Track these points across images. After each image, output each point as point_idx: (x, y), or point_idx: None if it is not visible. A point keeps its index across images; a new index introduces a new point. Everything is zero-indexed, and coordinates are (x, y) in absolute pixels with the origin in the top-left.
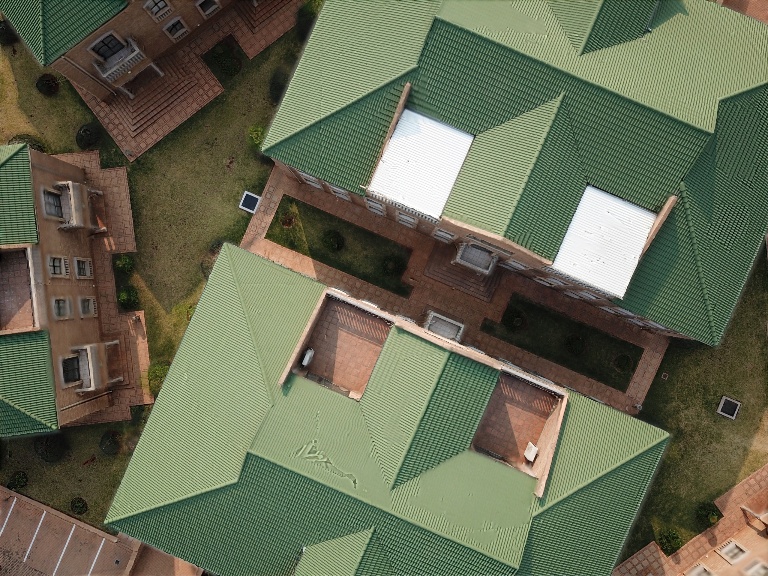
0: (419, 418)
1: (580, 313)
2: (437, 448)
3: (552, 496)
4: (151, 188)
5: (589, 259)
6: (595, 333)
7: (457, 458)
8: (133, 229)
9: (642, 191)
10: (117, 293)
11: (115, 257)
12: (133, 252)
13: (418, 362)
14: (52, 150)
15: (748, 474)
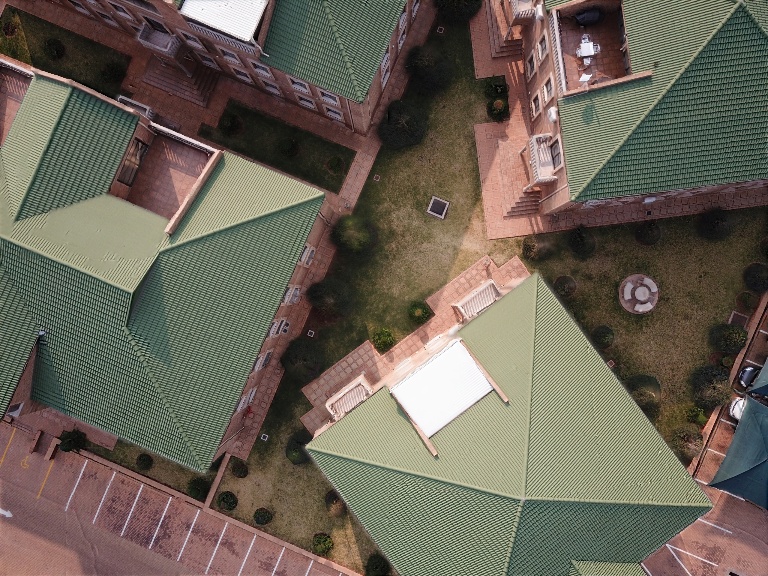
0: (42, 151)
1: (294, 117)
2: (68, 187)
3: (185, 236)
4: None
5: (217, 4)
6: (309, 136)
7: (93, 200)
8: None
9: None
10: None
11: None
12: None
13: (48, 102)
14: None
15: (458, 273)
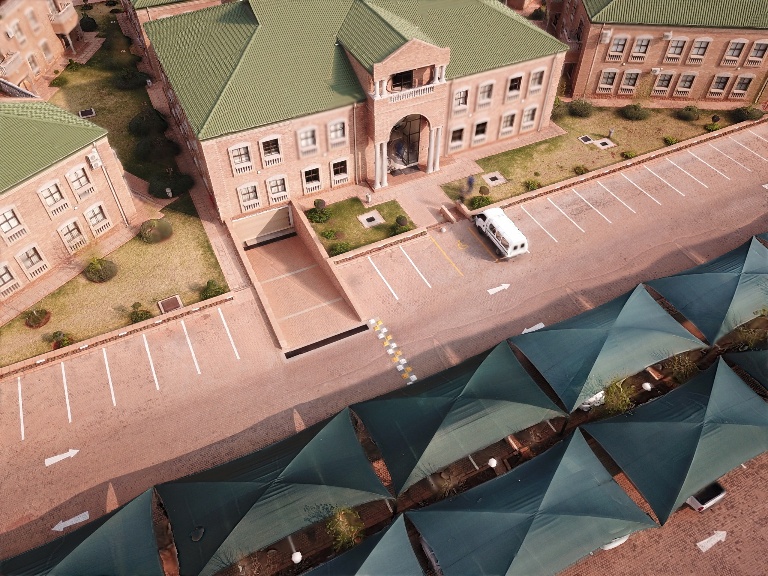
0: None
1: None
2: None
3: None
4: None
5: None
6: None
7: None
8: None
9: None
10: None
11: None
12: None
13: None
14: (543, 7)
15: None
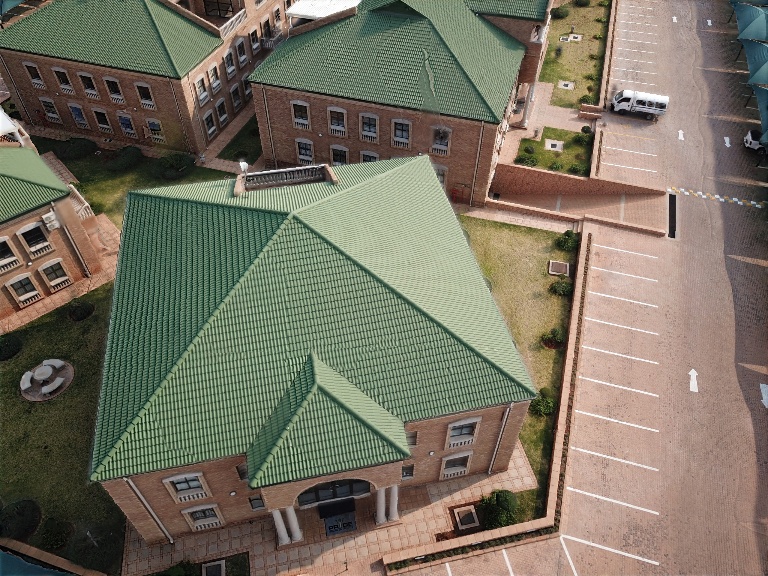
0: None
1: None
2: None
3: (150, 3)
4: None
5: (313, 2)
6: None
7: None
8: None
9: (360, 8)
10: None
11: None
12: None
13: None
14: None
15: None
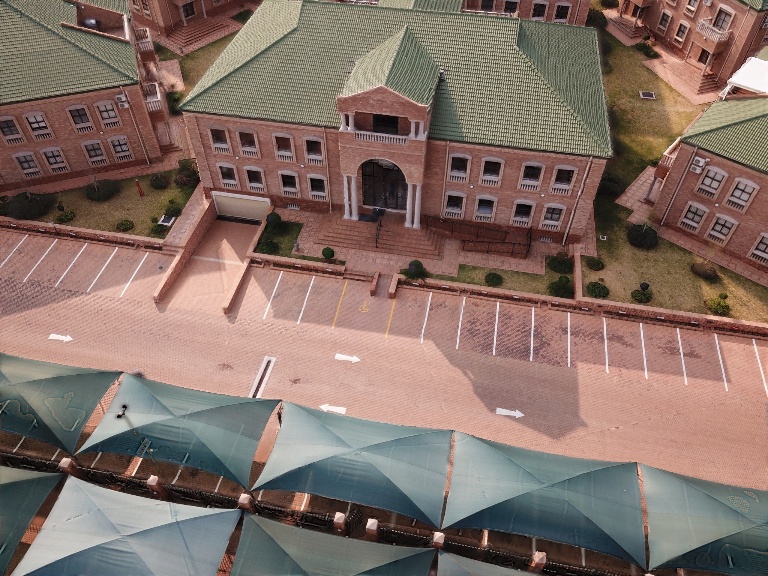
0: None
1: None
2: (437, 6)
3: None
4: (196, 64)
5: None
6: None
7: None
8: (183, 82)
9: None
10: (169, 108)
11: (168, 93)
12: (182, 90)
13: None
14: None
15: (689, 123)
